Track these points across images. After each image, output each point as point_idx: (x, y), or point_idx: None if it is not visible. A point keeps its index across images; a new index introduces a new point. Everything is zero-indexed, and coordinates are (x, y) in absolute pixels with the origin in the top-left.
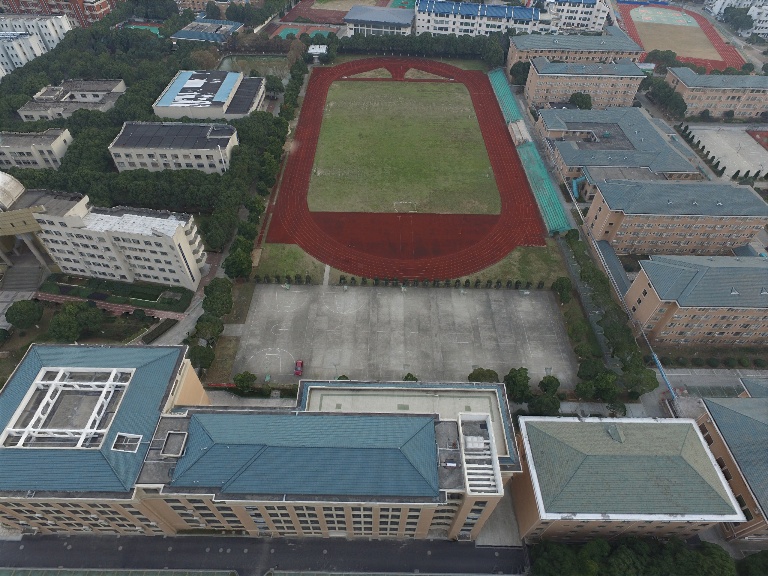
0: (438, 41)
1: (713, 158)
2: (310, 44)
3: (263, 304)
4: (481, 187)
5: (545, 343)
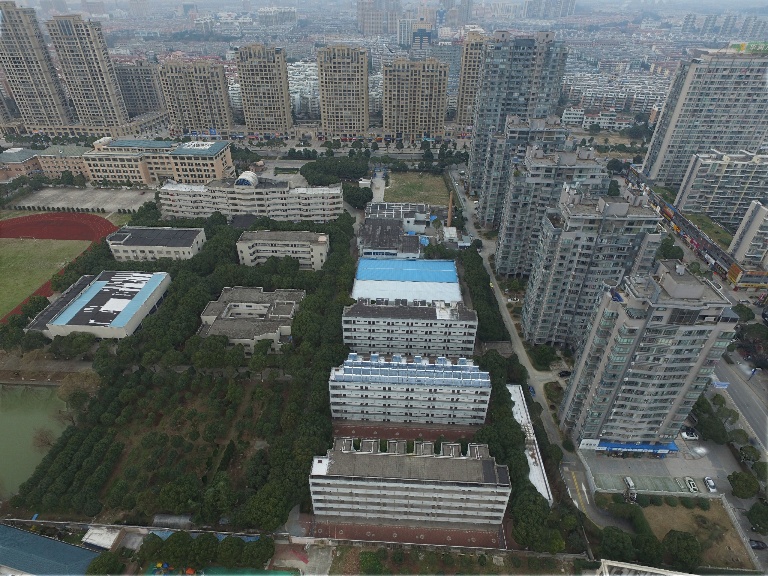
0: None
1: None
2: None
3: None
4: None
5: None
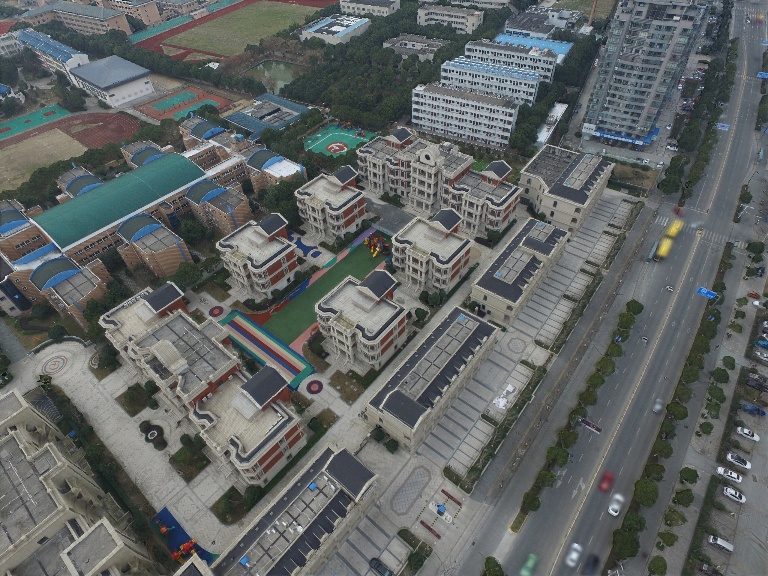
0: None
1: None
2: None
3: None
4: None
5: None
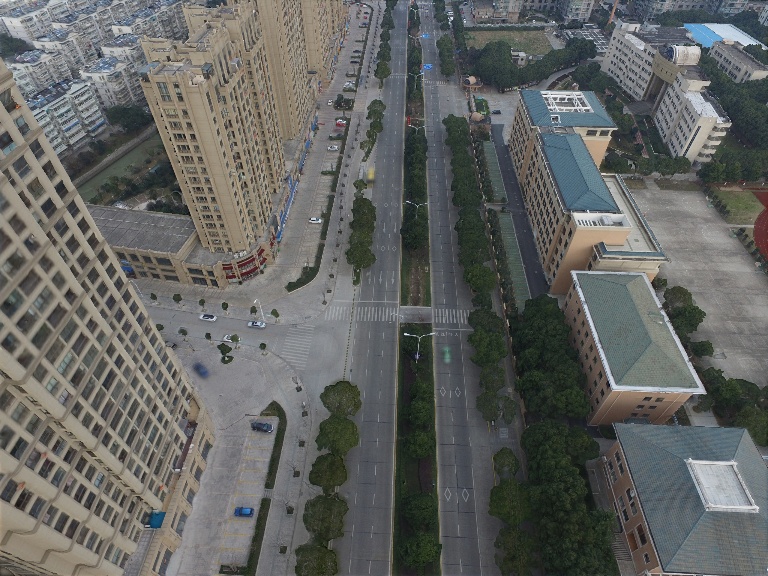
0: None
1: None
2: None
3: (684, 196)
4: None
5: (764, 374)
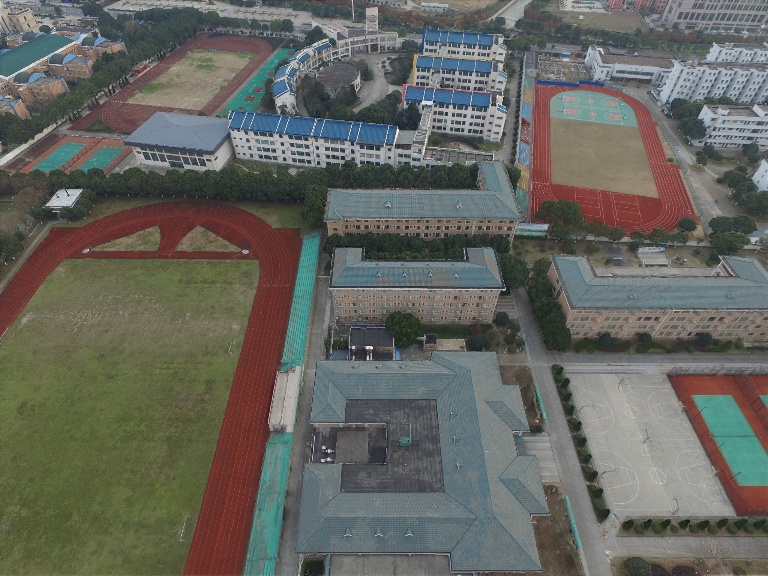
0: (240, 184)
1: (594, 475)
2: (58, 188)
3: None
4: (152, 574)
5: None
